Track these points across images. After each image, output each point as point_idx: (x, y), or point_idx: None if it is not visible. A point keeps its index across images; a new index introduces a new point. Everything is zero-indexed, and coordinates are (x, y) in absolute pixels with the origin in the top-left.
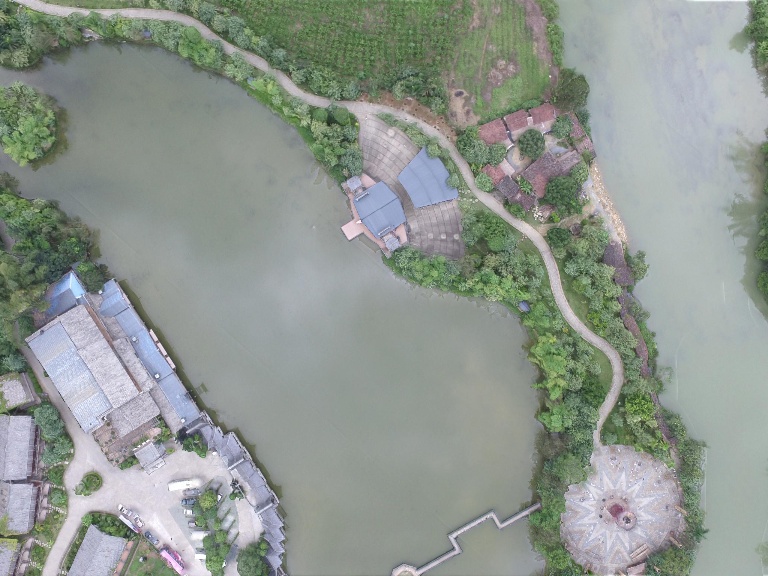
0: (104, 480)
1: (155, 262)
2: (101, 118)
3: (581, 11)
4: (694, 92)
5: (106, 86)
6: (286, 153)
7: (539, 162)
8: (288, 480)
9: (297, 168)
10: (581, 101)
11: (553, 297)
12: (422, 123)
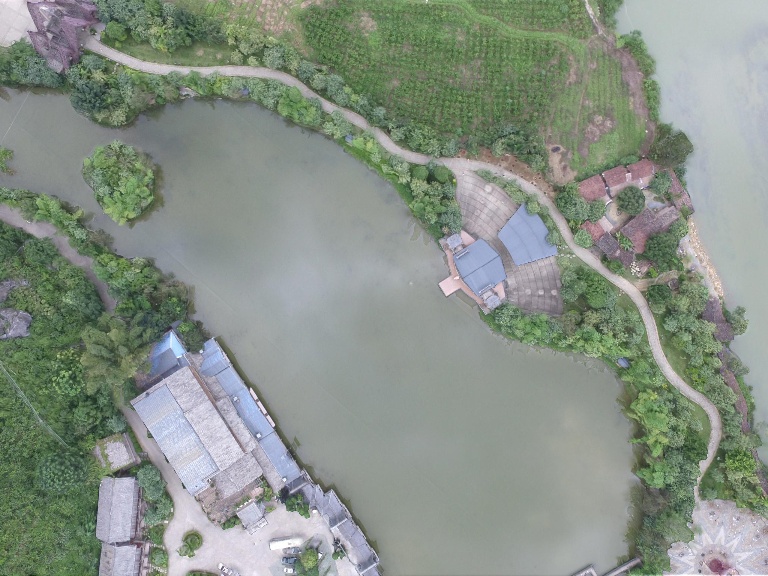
0: (204, 539)
1: (252, 319)
2: (197, 175)
3: (676, 65)
4: None
5: (202, 143)
6: (382, 209)
7: (638, 218)
8: (387, 537)
9: (394, 224)
10: (683, 159)
11: (651, 352)
12: (519, 179)
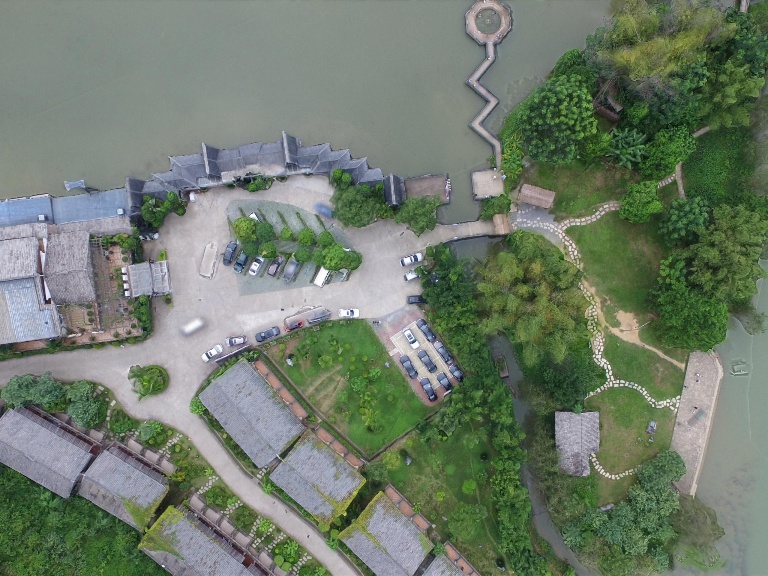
0: (160, 364)
1: None
2: None
3: None
4: None
5: None
6: None
7: None
8: (280, 121)
9: None
10: None
11: None
12: None
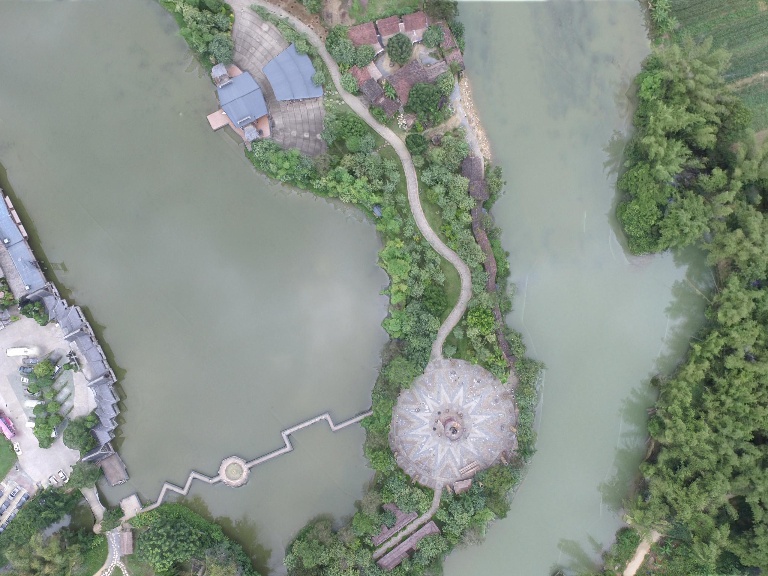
0: None
1: (21, 133)
2: None
3: None
4: (573, 17)
5: None
6: (161, 39)
7: (405, 68)
8: (129, 361)
9: (170, 54)
10: (448, 8)
11: (409, 206)
12: (296, 20)
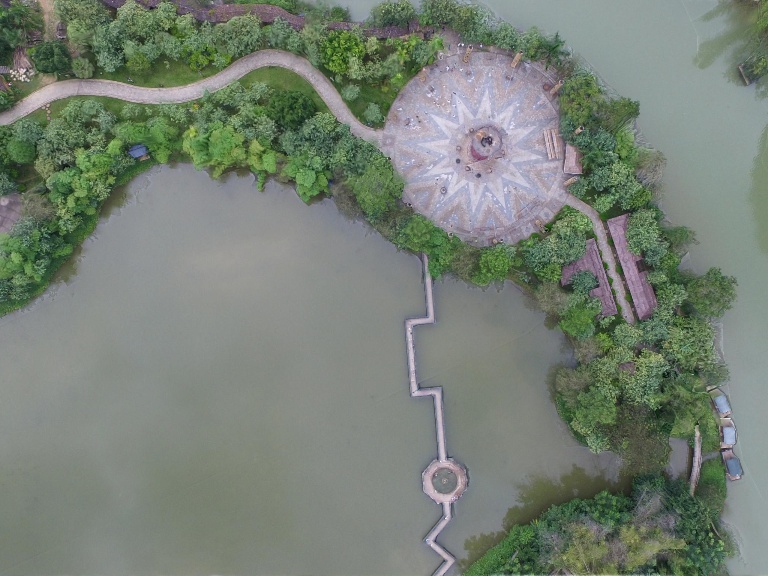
0: None
1: None
2: None
3: None
4: None
5: None
6: None
7: None
8: None
9: None
10: None
11: None
12: None
